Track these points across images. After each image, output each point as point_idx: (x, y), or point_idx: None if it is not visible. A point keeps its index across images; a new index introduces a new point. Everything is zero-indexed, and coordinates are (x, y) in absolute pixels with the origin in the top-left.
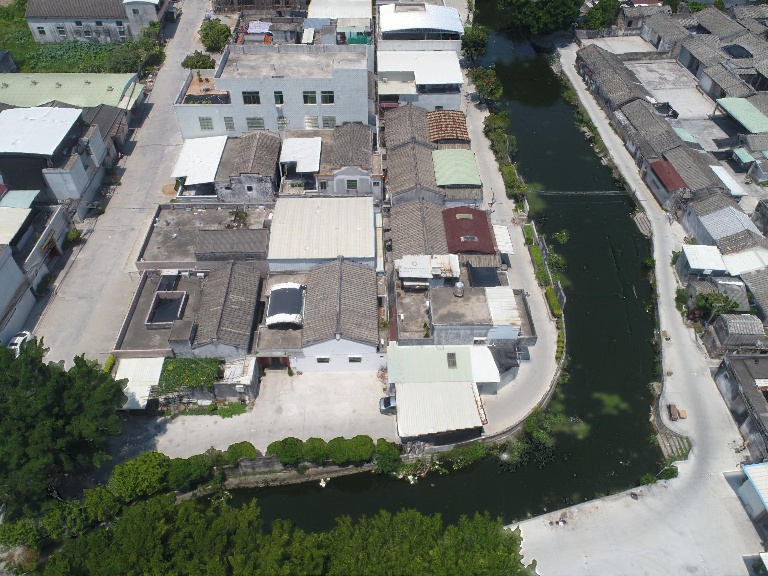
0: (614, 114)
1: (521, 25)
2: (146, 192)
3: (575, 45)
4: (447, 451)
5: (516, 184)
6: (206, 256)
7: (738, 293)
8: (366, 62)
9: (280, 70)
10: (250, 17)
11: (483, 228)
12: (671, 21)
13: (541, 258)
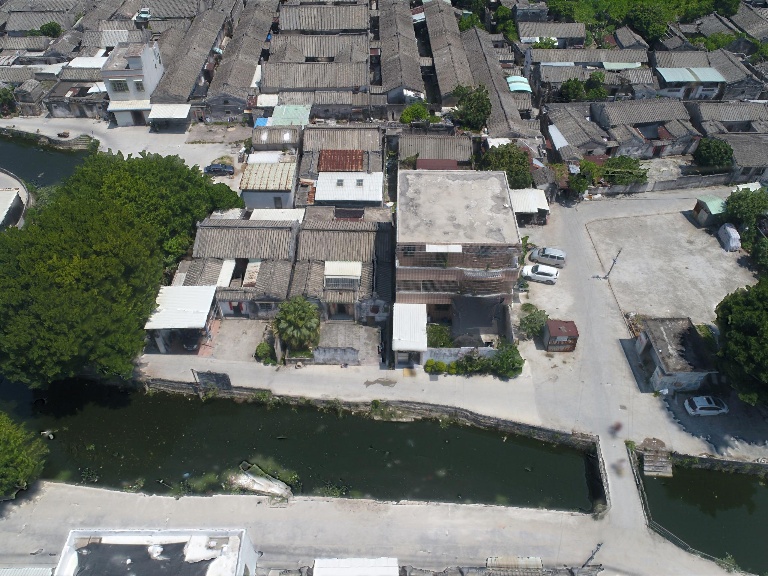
0: None
1: None
2: None
3: None
4: (24, 224)
5: None
6: None
7: (5, 87)
8: None
9: None
10: None
11: None
12: None
13: None
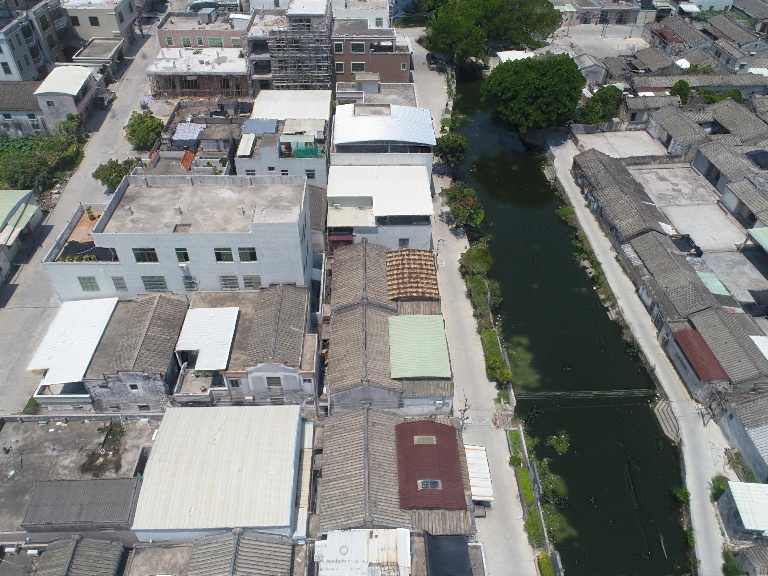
0: (622, 249)
1: (507, 121)
2: (10, 370)
3: (571, 143)
4: None
5: (499, 365)
6: (40, 528)
7: None
8: (298, 211)
9: (188, 214)
10: (188, 109)
11: (450, 460)
12: (683, 117)
13: (532, 492)
